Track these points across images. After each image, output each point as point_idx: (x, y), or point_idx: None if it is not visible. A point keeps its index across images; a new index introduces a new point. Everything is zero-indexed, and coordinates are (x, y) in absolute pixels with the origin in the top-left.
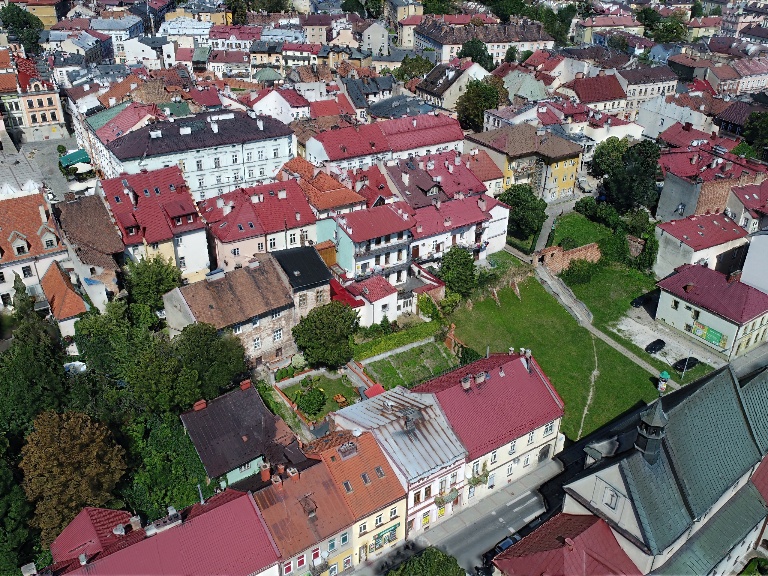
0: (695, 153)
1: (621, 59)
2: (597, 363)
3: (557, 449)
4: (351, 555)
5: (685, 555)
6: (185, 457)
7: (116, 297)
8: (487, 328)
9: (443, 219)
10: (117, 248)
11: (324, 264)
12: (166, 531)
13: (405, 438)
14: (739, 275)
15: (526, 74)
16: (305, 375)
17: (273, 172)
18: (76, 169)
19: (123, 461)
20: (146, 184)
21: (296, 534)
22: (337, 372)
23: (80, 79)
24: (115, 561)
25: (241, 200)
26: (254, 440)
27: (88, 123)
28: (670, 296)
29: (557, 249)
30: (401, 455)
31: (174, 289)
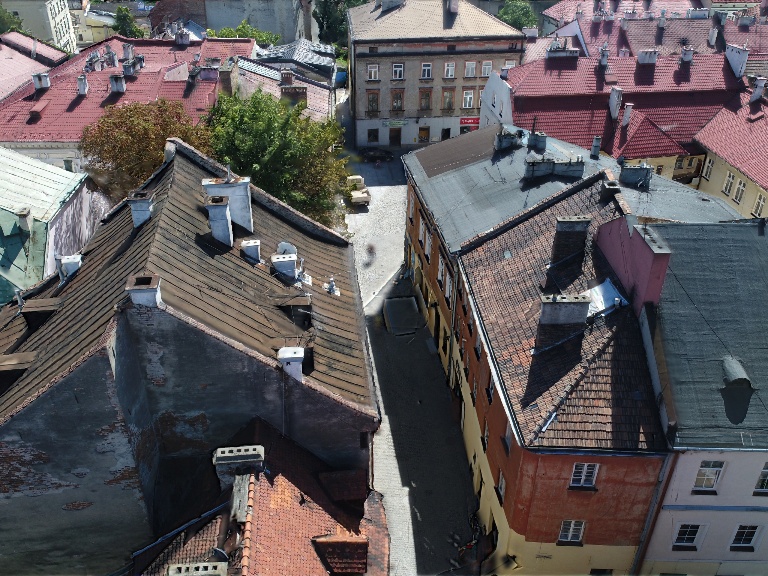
0: None
1: None
2: None
3: None
4: None
5: None
6: None
7: None
8: None
9: None
10: None
11: None
12: None
13: None
14: None
15: None
16: None
17: None
18: None
19: None
20: None
21: None
22: None
23: None
24: None
25: None
26: None
27: None
28: None
29: None
30: None
31: None
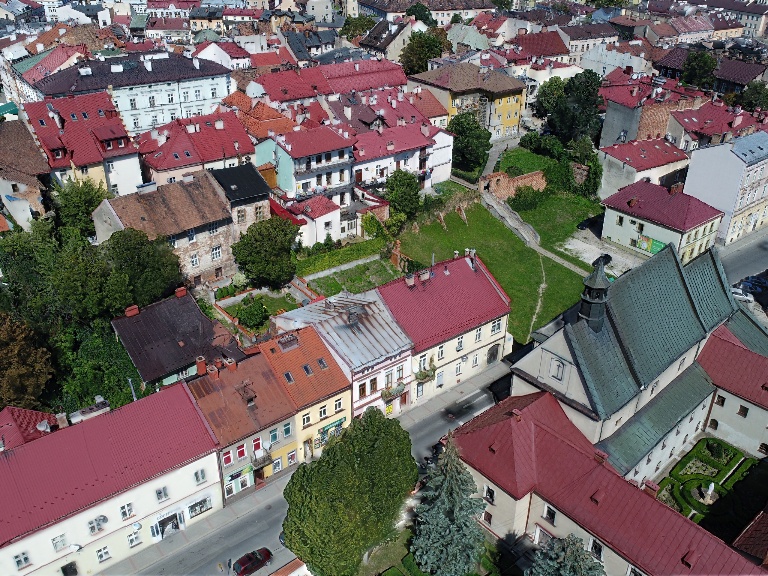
0: (635, 86)
1: (563, 19)
2: (545, 277)
3: (506, 350)
4: (295, 450)
5: (634, 426)
6: (119, 368)
7: (42, 217)
8: (434, 249)
9: (386, 144)
10: (42, 170)
11: (262, 179)
12: (93, 418)
13: (348, 331)
14: (680, 187)
15: (469, 27)
16: (247, 294)
17: (211, 111)
18: (4, 118)
19: (48, 364)
20: (73, 109)
21: (234, 422)
22: (280, 291)
23: (7, 35)
24: (37, 448)
25: (176, 130)
26: (191, 345)
27: (14, 69)
28: (615, 212)
29: (502, 175)
30: (344, 347)
31: (103, 201)
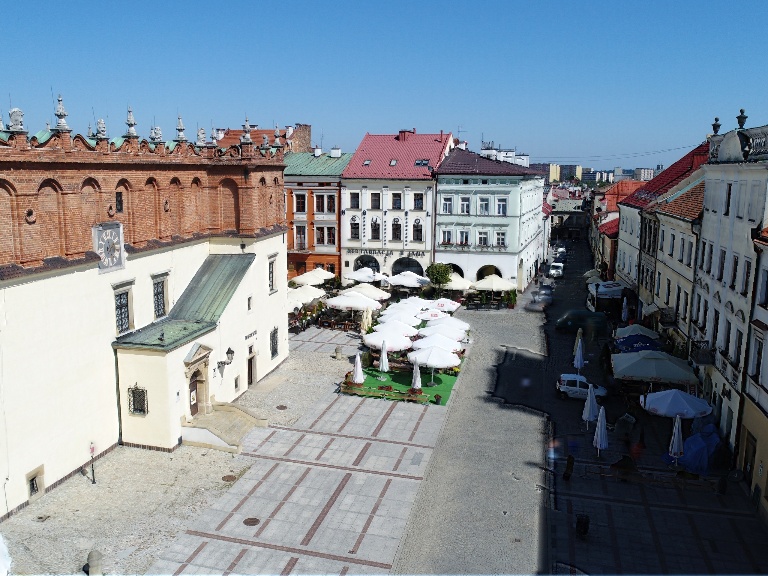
0: None
1: None
2: None
3: None
4: None
5: None
6: None
7: None
8: None
9: None
10: None
11: None
12: None
13: None
14: None
15: None
16: None
17: None
18: None
19: None
20: None
21: None
22: None
23: None
24: None
25: None
26: None
27: None
28: None
29: None
30: None
31: None
